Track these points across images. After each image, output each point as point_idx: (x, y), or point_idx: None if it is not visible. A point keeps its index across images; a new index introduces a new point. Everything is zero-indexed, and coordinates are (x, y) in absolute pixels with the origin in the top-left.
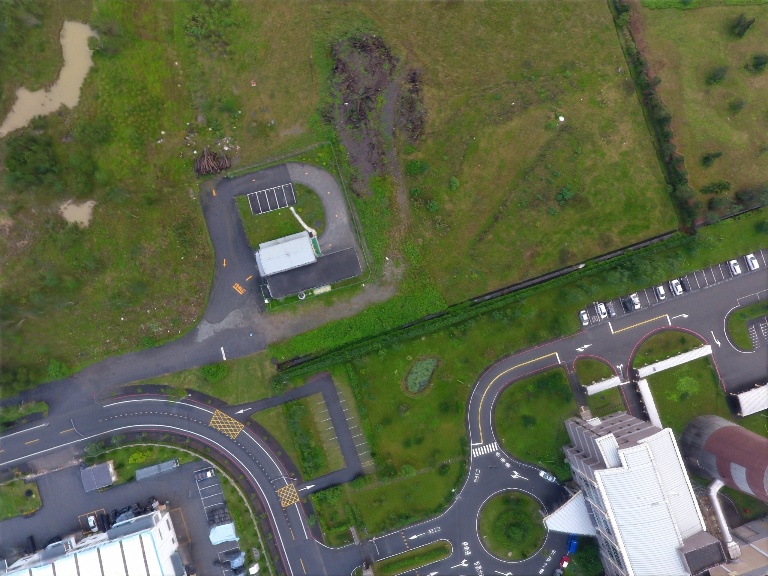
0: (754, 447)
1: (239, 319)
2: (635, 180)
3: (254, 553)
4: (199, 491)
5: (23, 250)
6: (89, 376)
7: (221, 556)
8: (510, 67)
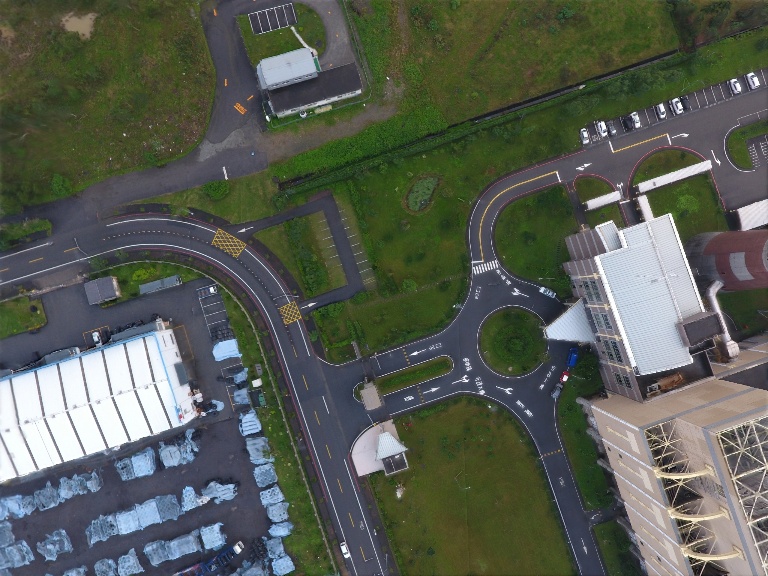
0: (753, 233)
1: (241, 139)
2: None
3: (257, 369)
4: (202, 308)
5: (25, 62)
6: (92, 195)
7: (224, 372)
8: None
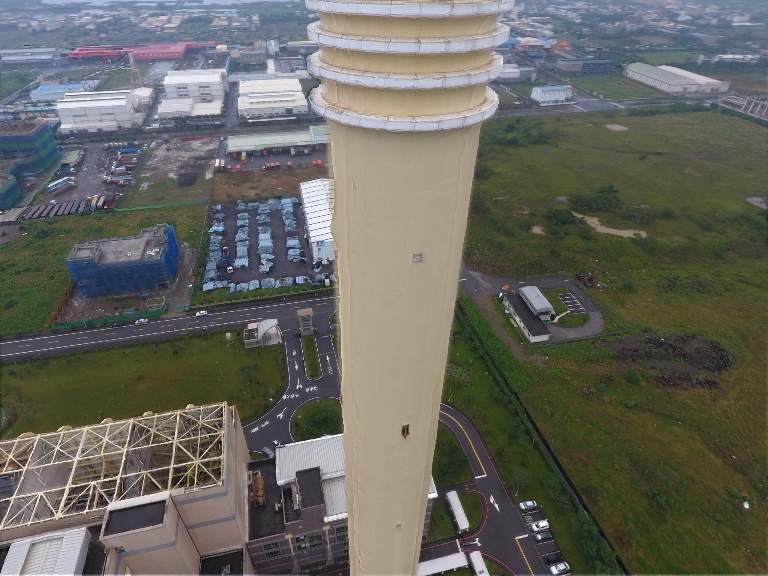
0: None
1: (486, 287)
2: None
3: (335, 285)
4: None
5: None
6: None
7: None
8: None
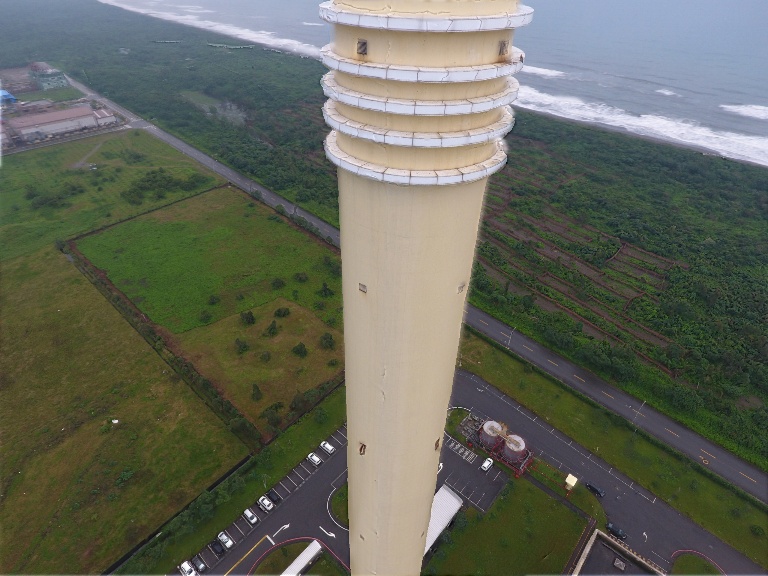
0: None
1: None
2: (195, 435)
3: None
4: None
5: None
6: None
7: None
8: (60, 406)
